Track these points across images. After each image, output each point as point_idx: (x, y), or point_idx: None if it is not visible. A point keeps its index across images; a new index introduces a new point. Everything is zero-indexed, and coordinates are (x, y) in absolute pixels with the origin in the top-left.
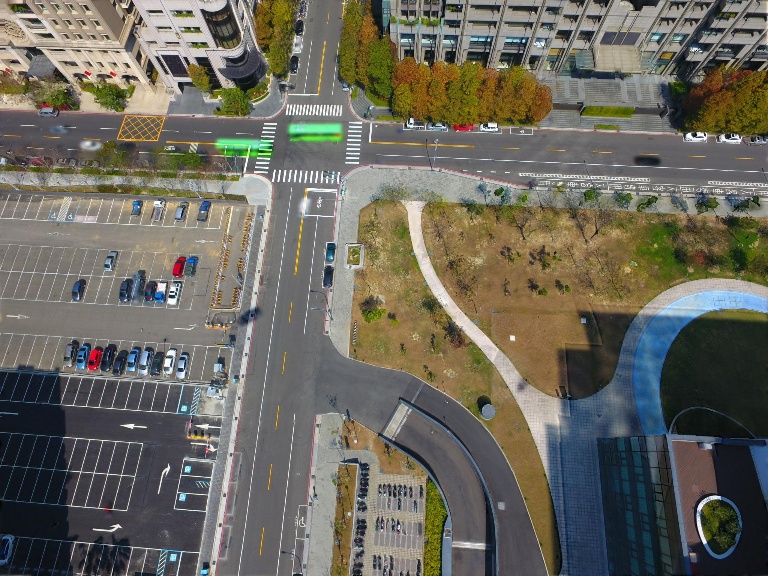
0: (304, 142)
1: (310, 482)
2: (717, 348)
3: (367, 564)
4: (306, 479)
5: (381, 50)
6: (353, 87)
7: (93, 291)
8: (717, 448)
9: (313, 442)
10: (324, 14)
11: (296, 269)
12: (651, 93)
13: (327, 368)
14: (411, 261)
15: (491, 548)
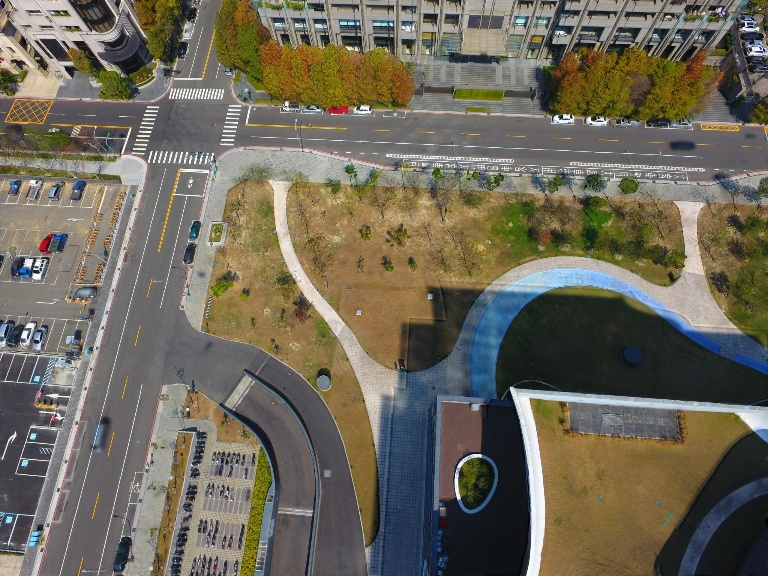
0: (183, 124)
1: (149, 450)
2: (557, 323)
3: (193, 528)
4: (145, 447)
5: (248, 33)
6: (236, 72)
7: None
8: (488, 409)
9: (156, 411)
10: (218, 1)
11: (160, 246)
12: (525, 77)
13: (178, 341)
14: (272, 239)
15: None
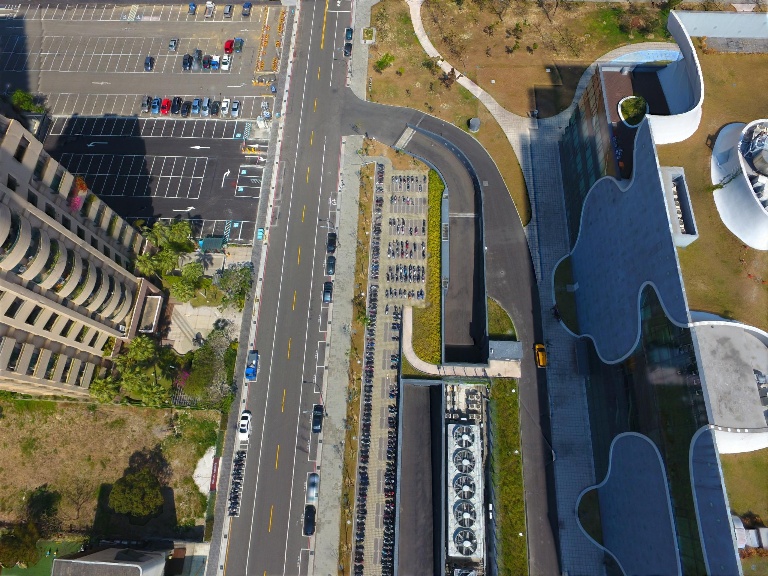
0: None
1: (339, 178)
2: None
3: (385, 224)
4: (336, 176)
5: None
6: None
7: (161, 65)
8: (634, 74)
9: (340, 153)
10: None
11: (322, 46)
12: None
13: (349, 107)
14: (413, 38)
15: (479, 215)
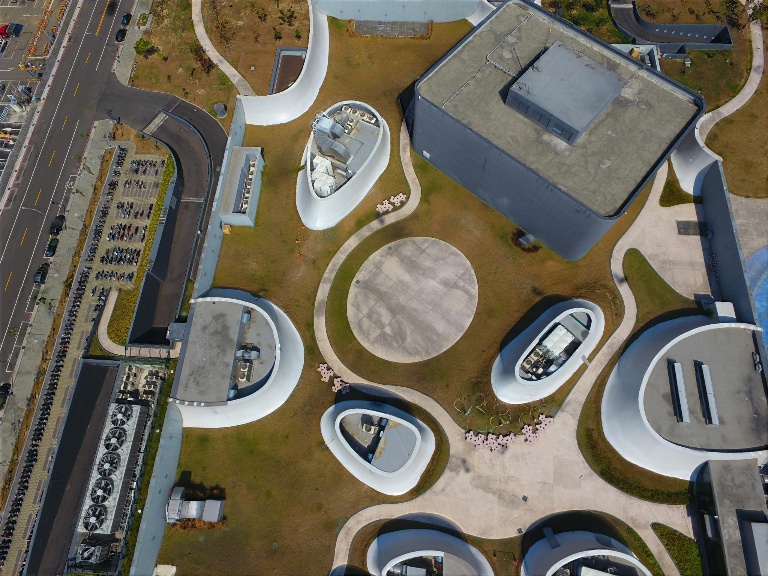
0: None
1: (82, 161)
2: None
3: (114, 207)
4: (79, 159)
5: None
6: None
7: None
8: None
9: (89, 137)
10: None
11: (98, 31)
12: None
13: (109, 92)
14: (188, 24)
15: None
